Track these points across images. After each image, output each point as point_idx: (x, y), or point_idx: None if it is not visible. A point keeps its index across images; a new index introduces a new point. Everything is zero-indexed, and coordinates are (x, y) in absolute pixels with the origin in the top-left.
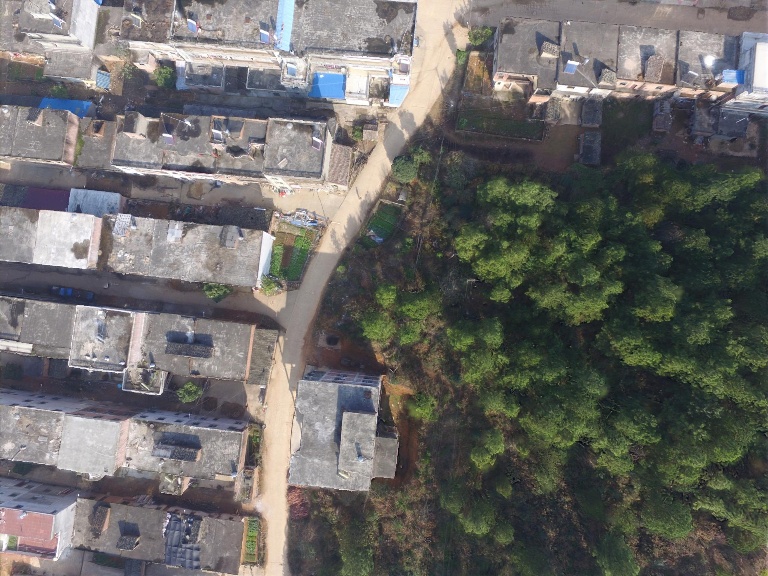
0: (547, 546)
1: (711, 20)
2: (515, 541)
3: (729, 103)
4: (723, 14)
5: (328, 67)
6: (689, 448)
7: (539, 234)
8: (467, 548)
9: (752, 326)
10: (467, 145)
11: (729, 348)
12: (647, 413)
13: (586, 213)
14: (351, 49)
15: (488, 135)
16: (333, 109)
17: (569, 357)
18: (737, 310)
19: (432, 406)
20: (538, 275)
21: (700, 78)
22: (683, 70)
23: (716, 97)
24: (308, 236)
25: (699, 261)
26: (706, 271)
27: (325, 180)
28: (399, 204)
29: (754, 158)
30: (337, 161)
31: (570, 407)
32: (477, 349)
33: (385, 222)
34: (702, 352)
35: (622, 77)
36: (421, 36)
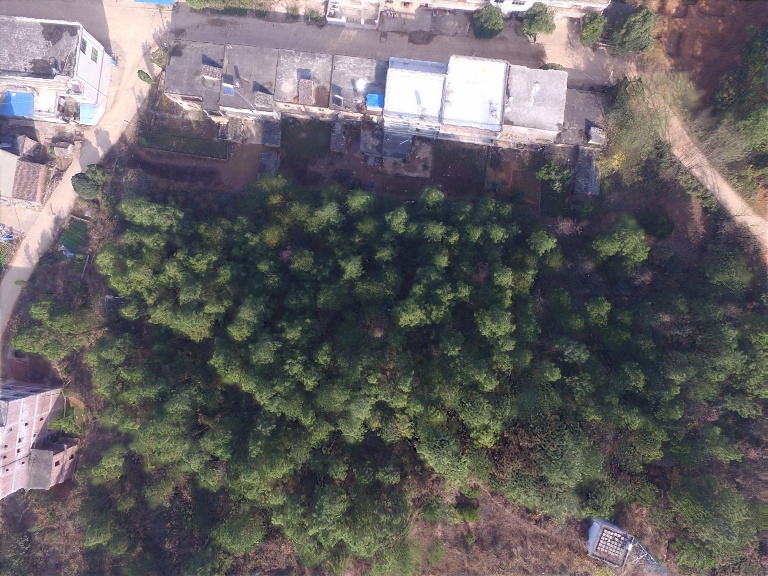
0: (169, 558)
1: (393, 44)
2: (143, 552)
3: (387, 125)
4: (404, 38)
5: (12, 86)
6: (245, 464)
7: (163, 253)
8: (109, 559)
9: (321, 346)
10: (158, 163)
11: (286, 367)
12: (226, 429)
13: (204, 233)
14: (17, 70)
15: (176, 153)
16: (34, 126)
17: (203, 373)
18: (325, 329)
19: (94, 419)
20: (162, 293)
21: (351, 101)
22: (336, 93)
23: (376, 119)
24: (4, 250)
25: (305, 281)
26: (299, 291)
27: (4, 196)
28: (85, 220)
29: (427, 178)
30: (24, 178)
31: (156, 423)
32: (99, 365)
33: (76, 237)
34: (265, 371)
35: (279, 99)
36: (120, 56)
